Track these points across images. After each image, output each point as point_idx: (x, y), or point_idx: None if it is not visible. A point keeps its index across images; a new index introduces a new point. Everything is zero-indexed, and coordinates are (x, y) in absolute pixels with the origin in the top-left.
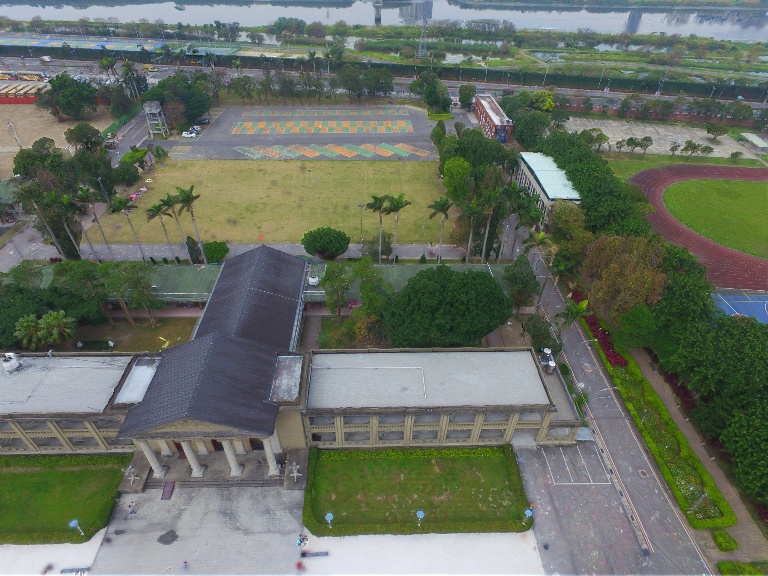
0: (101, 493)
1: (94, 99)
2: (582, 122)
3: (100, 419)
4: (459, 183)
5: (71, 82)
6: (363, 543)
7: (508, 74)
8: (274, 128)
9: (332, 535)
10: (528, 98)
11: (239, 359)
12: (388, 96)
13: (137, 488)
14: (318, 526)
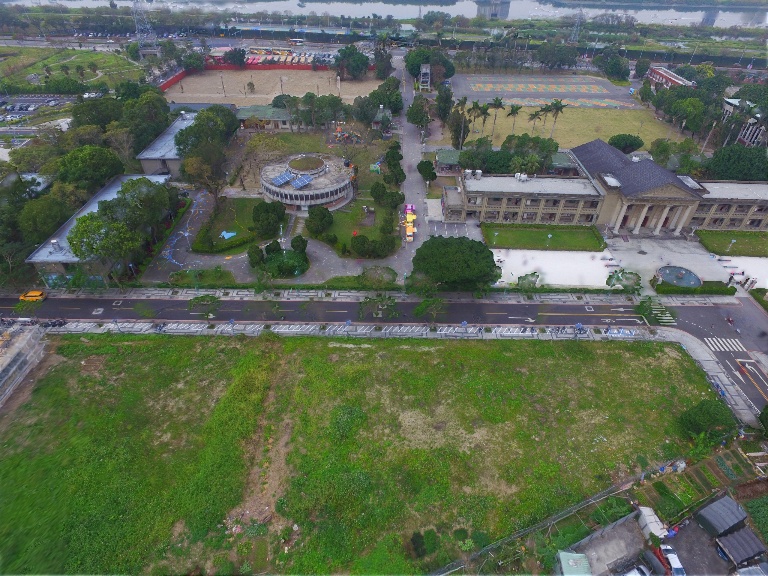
0: (590, 238)
1: (367, 64)
2: (737, 89)
3: (593, 199)
4: (699, 112)
5: None
6: (745, 259)
7: (666, 53)
8: (502, 88)
9: (729, 254)
10: None
11: None
12: (571, 69)
13: (611, 235)
14: (720, 250)
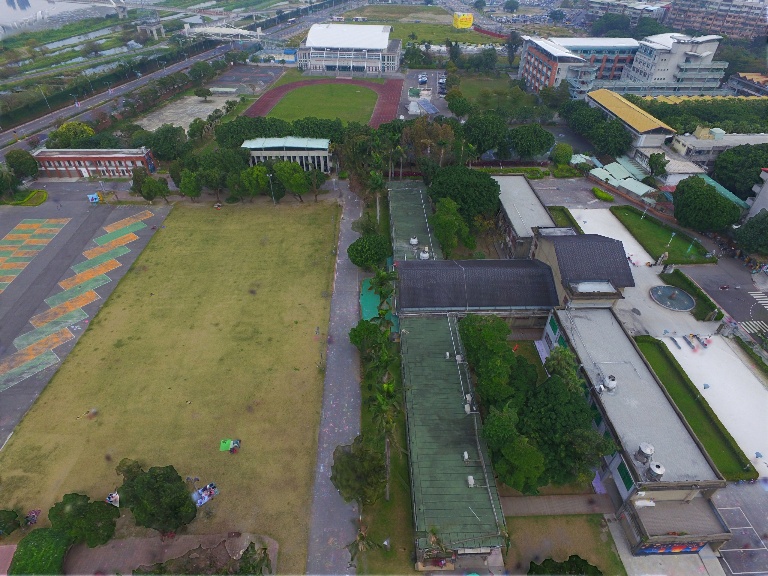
0: None
1: None
2: None
3: None
4: None
5: None
6: None
7: None
8: None
9: None
10: (67, 136)
11: None
12: None
13: None
14: None
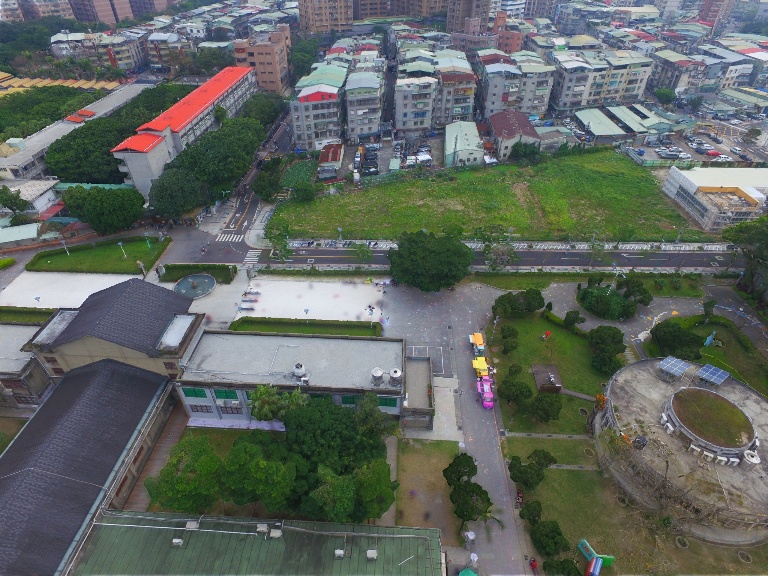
0: None
1: None
2: None
3: None
4: None
5: None
6: None
7: None
8: None
9: None
10: None
11: None
12: None
13: None
14: None
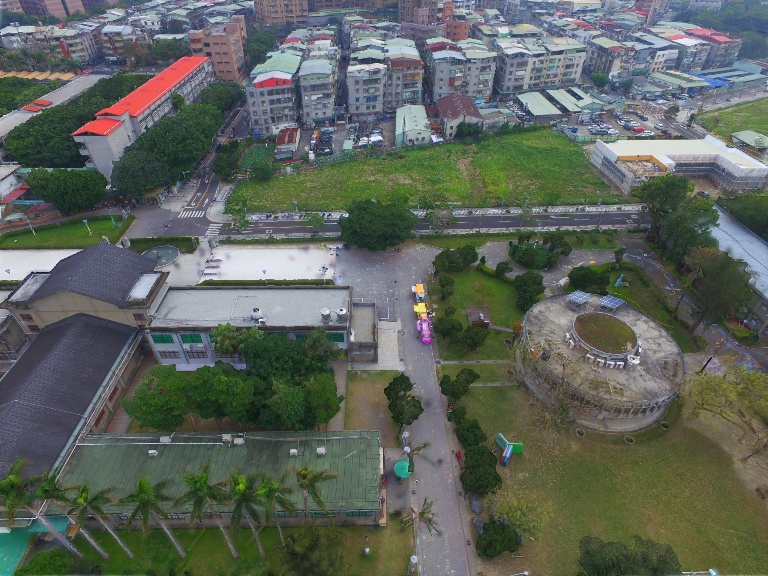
0: None
1: None
2: None
3: None
4: None
5: None
6: None
7: None
8: None
9: None
10: None
11: None
12: None
13: None
14: None
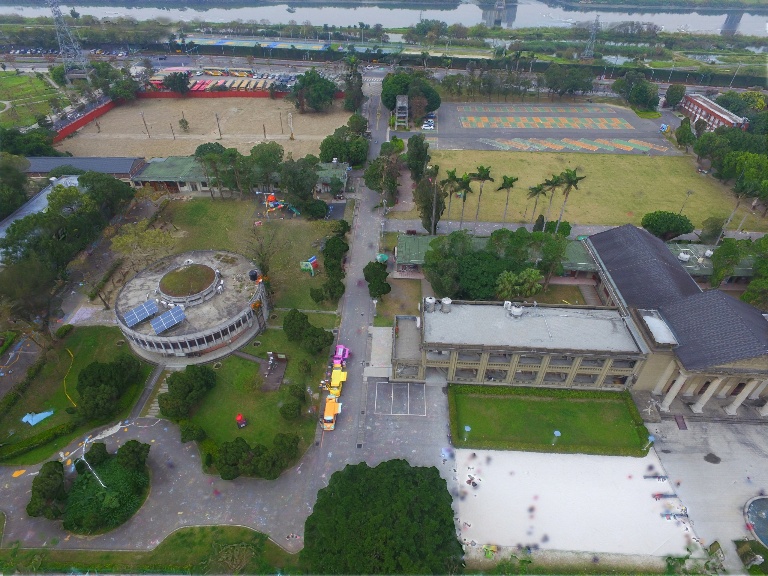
0: (622, 421)
1: (333, 93)
2: None
3: (628, 357)
4: (767, 175)
5: (318, 78)
6: None
7: (703, 75)
8: (499, 123)
9: None
10: None
11: (748, 313)
12: (585, 95)
13: (657, 418)
14: None
